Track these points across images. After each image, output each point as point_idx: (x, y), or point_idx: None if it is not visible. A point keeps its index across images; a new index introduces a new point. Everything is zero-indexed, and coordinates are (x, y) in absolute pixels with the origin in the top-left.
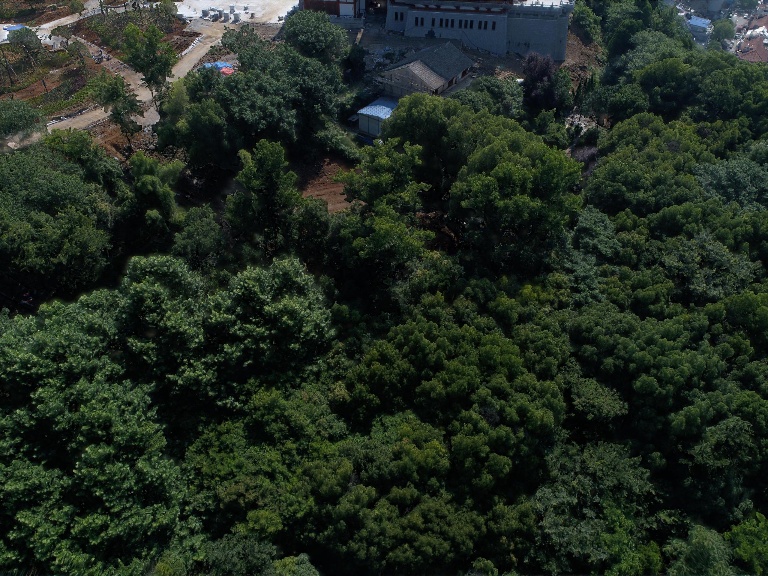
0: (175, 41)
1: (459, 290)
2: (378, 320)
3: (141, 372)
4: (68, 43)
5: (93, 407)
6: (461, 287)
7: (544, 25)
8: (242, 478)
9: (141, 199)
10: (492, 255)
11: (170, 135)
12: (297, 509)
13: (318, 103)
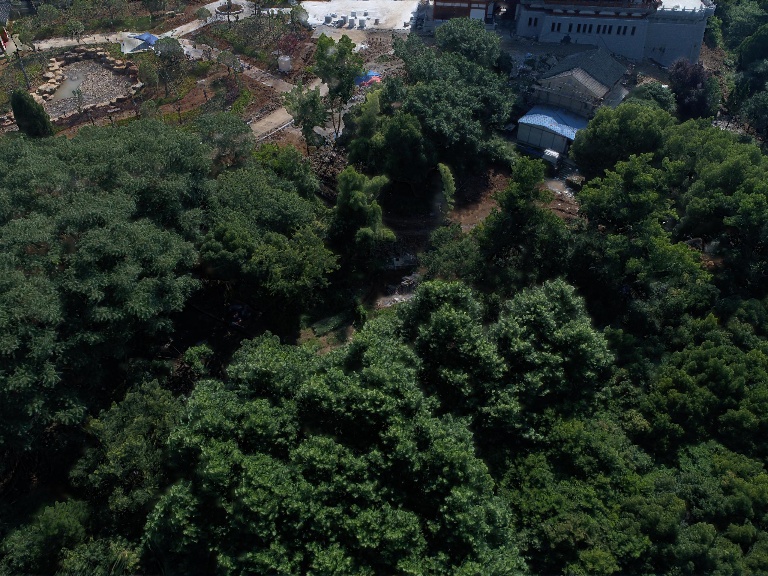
0: (310, 49)
1: (728, 311)
2: (648, 343)
3: (450, 404)
4: (210, 52)
5: (445, 446)
6: (732, 308)
7: (682, 30)
8: (566, 515)
9: (346, 215)
10: (751, 274)
11: (365, 149)
12: (632, 548)
13: (493, 113)
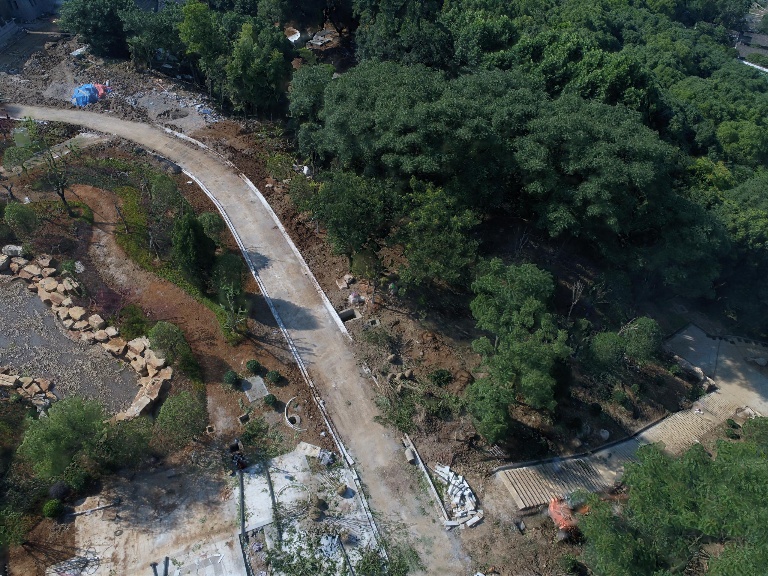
0: None
1: None
2: None
3: None
4: None
5: None
6: None
7: None
8: None
9: None
10: None
11: None
12: None
13: None
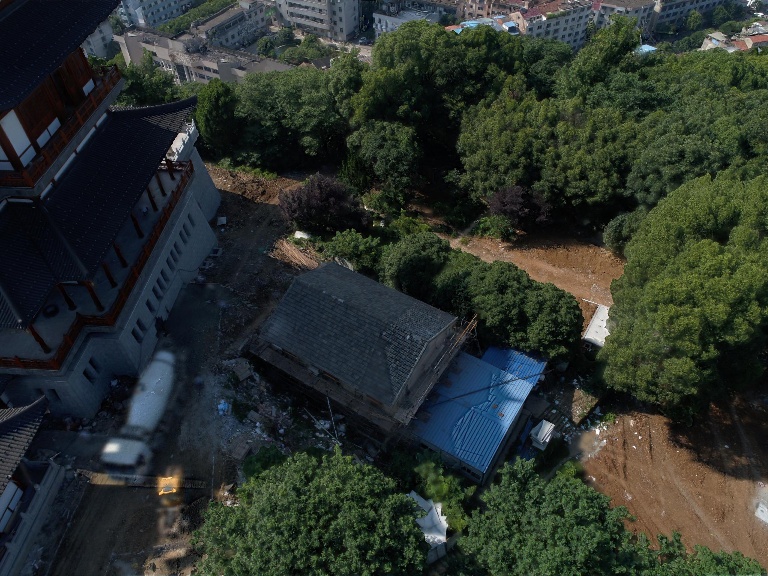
0: None
1: None
2: None
3: None
4: None
5: None
6: None
7: None
8: None
9: None
10: None
11: None
12: None
13: None
